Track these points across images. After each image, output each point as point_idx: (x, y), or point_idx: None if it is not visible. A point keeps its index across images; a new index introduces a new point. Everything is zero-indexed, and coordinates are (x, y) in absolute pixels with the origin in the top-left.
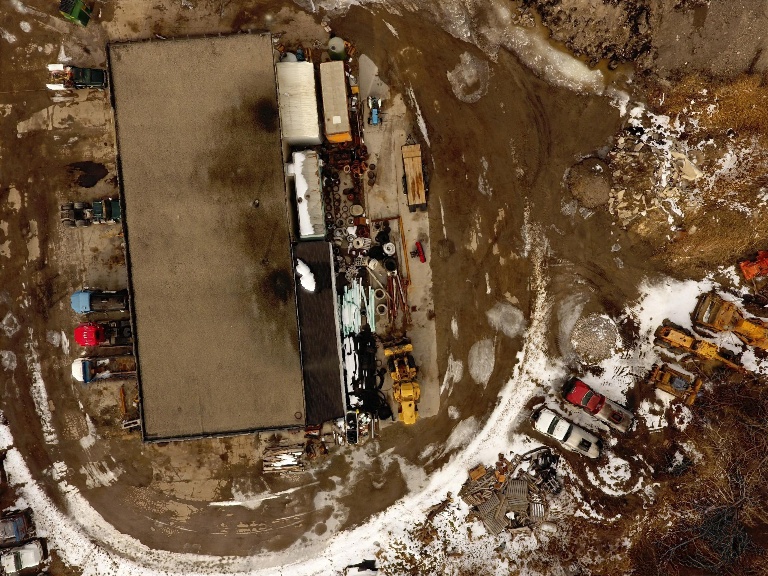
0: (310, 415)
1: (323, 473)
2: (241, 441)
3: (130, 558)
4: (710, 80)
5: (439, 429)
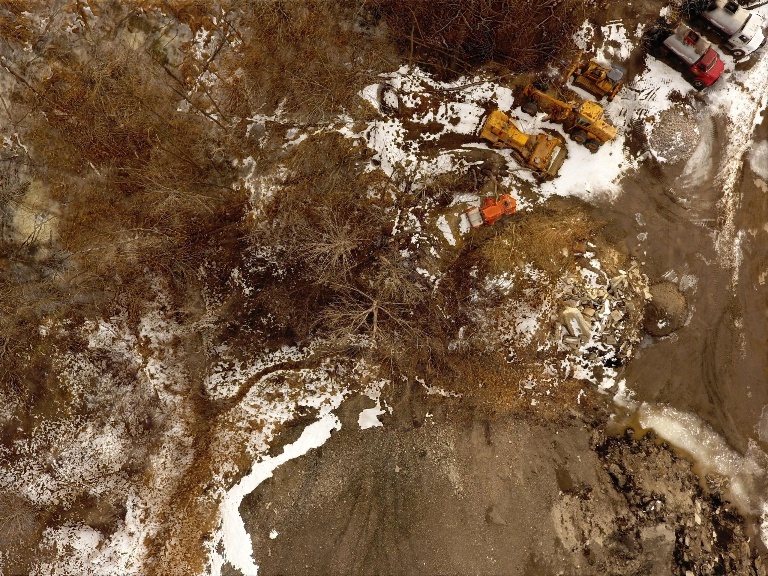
0: None
1: None
2: None
3: None
4: (528, 415)
5: None
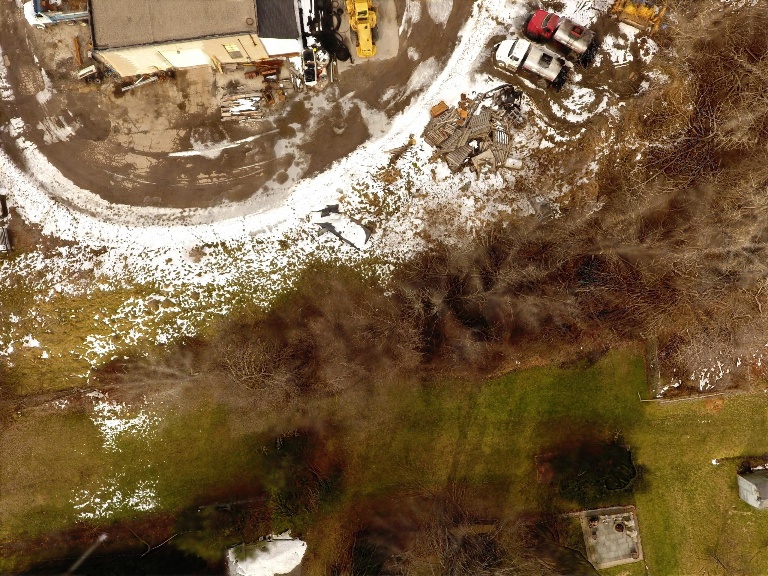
0: (262, 26)
1: (283, 120)
2: (198, 89)
3: (90, 214)
4: None
5: (399, 71)
